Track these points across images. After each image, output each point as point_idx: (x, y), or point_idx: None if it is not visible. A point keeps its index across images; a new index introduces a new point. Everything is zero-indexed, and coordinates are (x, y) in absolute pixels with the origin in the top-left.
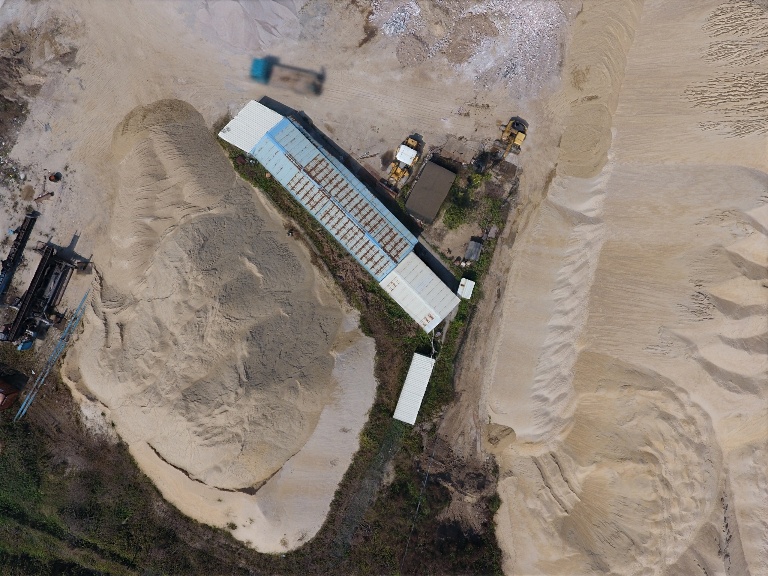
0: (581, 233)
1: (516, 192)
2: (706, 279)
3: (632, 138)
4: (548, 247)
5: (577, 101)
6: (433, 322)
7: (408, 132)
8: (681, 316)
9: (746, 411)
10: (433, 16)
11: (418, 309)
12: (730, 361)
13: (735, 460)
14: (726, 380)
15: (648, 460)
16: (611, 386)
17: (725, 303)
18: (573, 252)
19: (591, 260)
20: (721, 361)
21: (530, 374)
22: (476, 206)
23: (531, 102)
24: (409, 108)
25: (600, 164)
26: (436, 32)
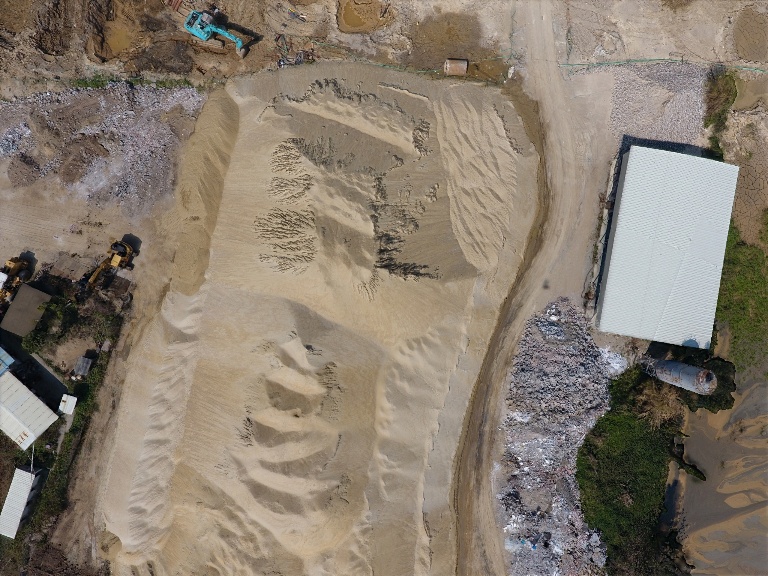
0: (175, 351)
1: (130, 306)
2: (252, 406)
3: (221, 261)
4: (151, 362)
5: (187, 219)
6: (28, 440)
7: (20, 250)
8: (236, 439)
9: (299, 528)
10: (42, 137)
11: (13, 427)
12: (277, 483)
13: (312, 567)
14: (273, 501)
15: (210, 575)
16: (191, 501)
17: (265, 430)
18: (167, 369)
19: (187, 376)
20: (270, 482)
21: (129, 487)
22: (88, 321)
23: (144, 220)
24: (20, 226)
25: (197, 284)
26: (46, 153)
